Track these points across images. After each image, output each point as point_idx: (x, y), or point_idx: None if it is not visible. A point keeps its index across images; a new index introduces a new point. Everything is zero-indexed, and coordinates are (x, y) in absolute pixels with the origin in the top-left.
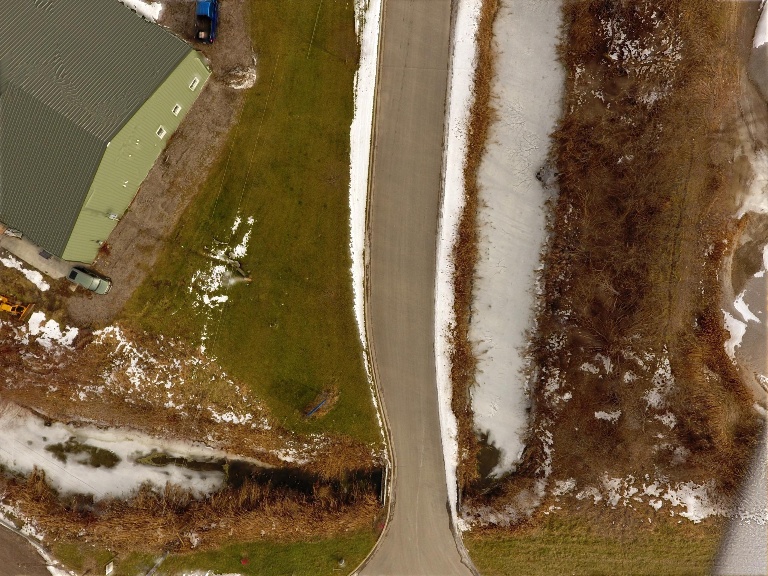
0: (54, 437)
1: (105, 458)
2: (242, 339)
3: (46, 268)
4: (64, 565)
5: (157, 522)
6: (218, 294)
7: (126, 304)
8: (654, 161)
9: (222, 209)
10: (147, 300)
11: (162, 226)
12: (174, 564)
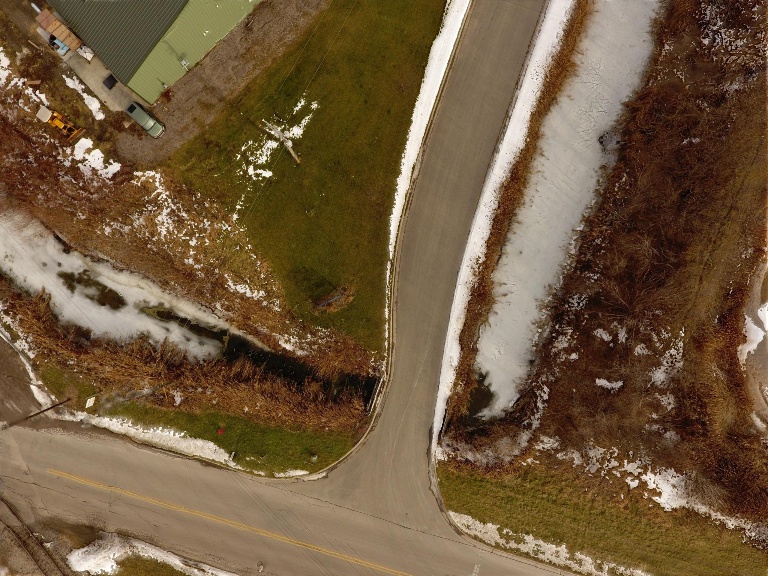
0: (69, 265)
1: (113, 299)
2: (275, 217)
3: (106, 98)
4: (47, 388)
5: (147, 372)
6: (264, 168)
7: (173, 154)
8: (719, 148)
9: (289, 87)
10: (194, 156)
11: (227, 88)
12: (154, 415)
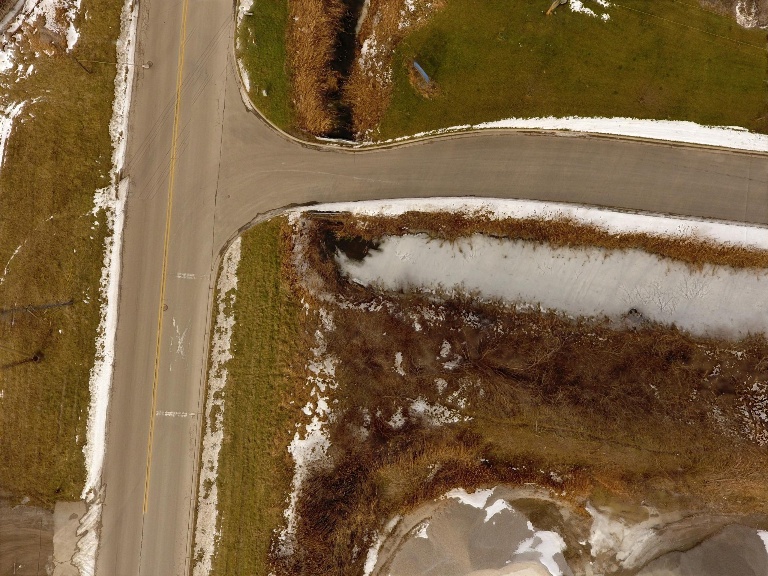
0: None
1: None
2: (489, 4)
3: None
4: None
5: None
6: None
7: None
8: (656, 416)
9: None
10: None
11: None
12: None
